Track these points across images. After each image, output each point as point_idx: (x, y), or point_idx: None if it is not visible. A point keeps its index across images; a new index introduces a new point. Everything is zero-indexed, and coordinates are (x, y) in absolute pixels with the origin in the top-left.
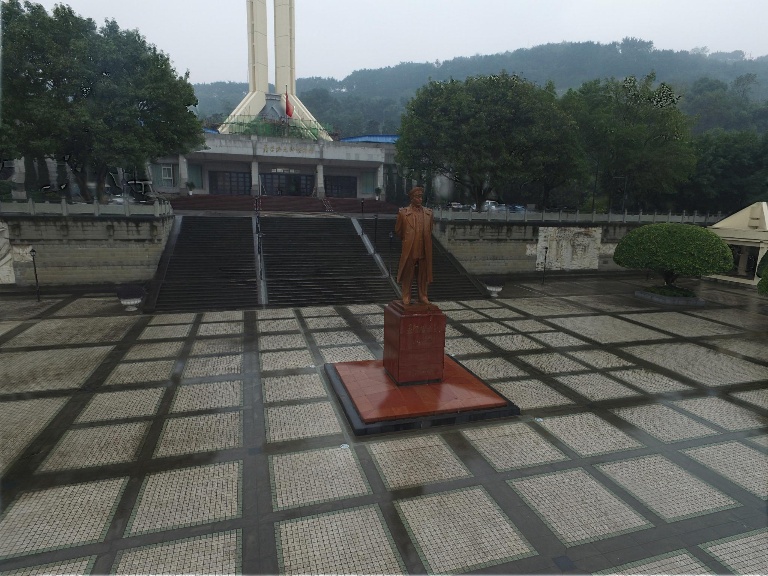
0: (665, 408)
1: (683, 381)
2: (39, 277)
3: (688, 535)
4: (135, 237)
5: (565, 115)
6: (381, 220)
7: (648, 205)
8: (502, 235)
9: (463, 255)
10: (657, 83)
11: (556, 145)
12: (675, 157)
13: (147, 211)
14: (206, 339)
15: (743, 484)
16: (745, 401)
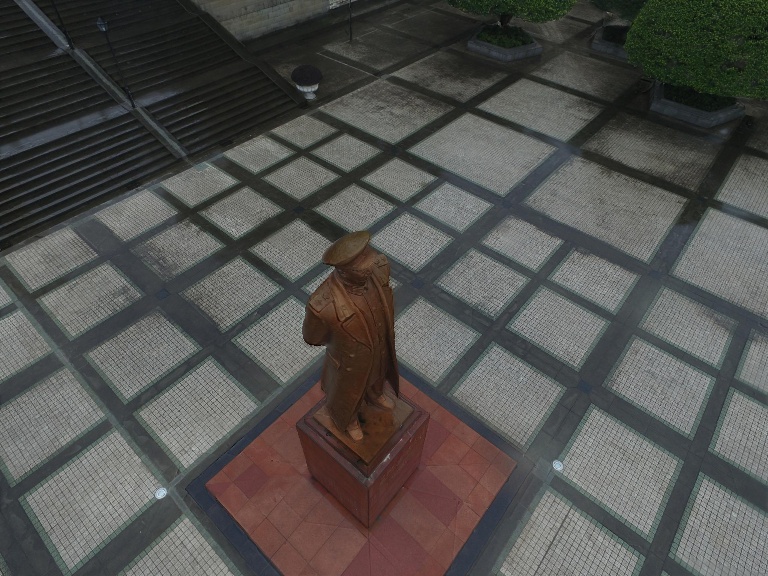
0: (645, 346)
1: (622, 263)
2: None
3: None
4: None
5: None
6: None
7: None
8: None
9: (226, 9)
10: None
11: None
12: None
13: None
14: None
15: None
16: (689, 284)
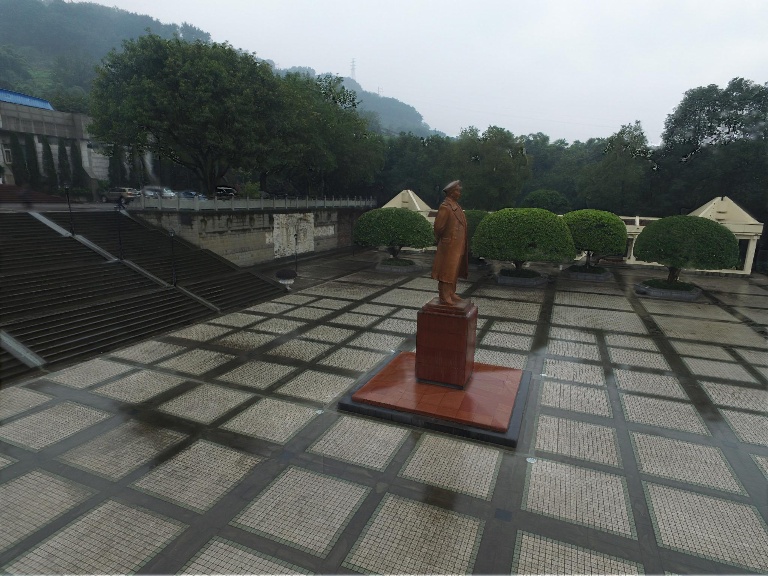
0: (557, 341)
1: (524, 322)
2: None
3: (704, 401)
4: None
5: (308, 105)
6: (76, 213)
7: (334, 192)
8: (246, 225)
9: (215, 250)
10: (340, 86)
11: (305, 134)
12: (376, 153)
13: None
14: (73, 448)
15: (656, 367)
16: (563, 325)
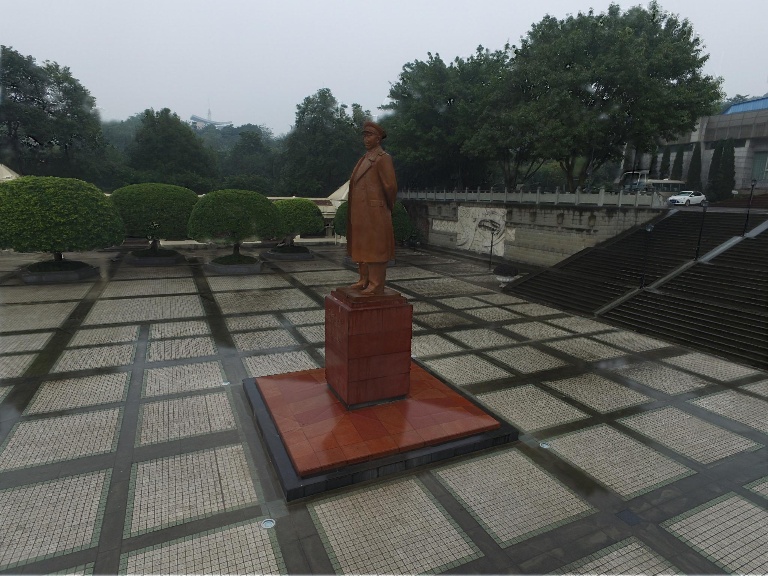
0: None
1: None
2: (515, 254)
3: None
4: (577, 226)
5: None
6: None
7: None
8: None
9: None
10: None
11: None
12: None
13: (593, 200)
14: (456, 314)
15: None
16: None
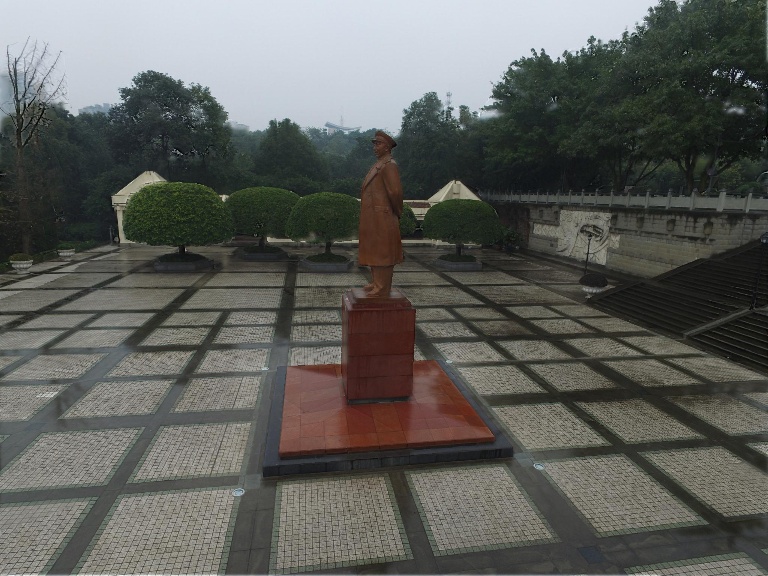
0: None
1: None
2: (618, 263)
3: None
4: (690, 234)
5: None
6: None
7: None
8: None
9: None
10: None
11: None
12: None
13: (711, 204)
14: (518, 323)
15: None
16: None
